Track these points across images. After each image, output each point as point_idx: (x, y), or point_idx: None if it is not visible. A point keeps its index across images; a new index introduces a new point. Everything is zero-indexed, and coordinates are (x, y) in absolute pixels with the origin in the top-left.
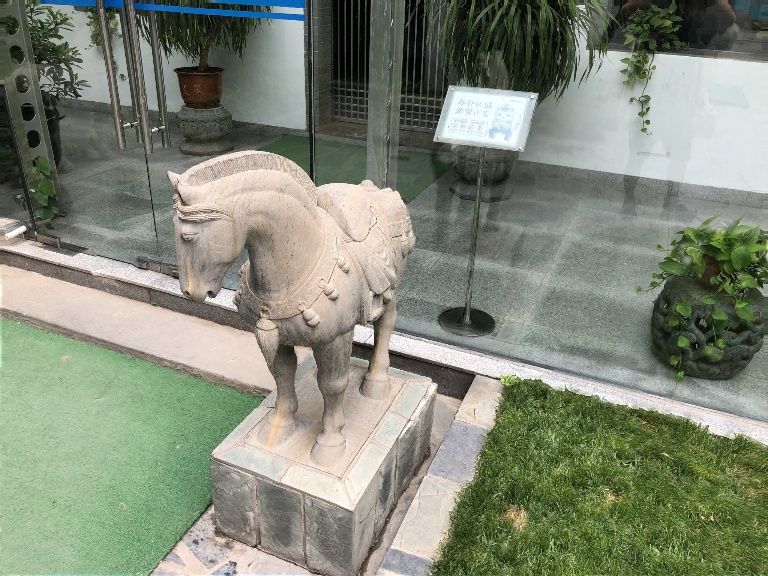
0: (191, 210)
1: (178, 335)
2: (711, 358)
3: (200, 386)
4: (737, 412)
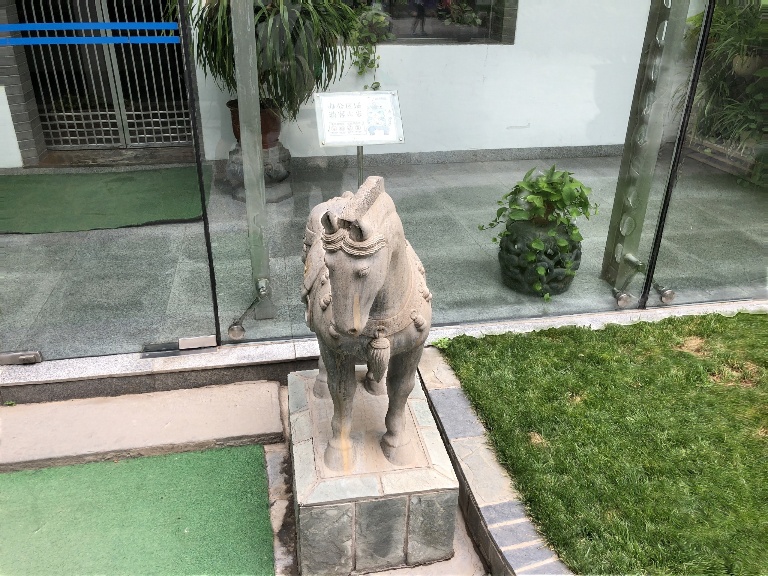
0: (369, 244)
1: (76, 425)
2: (560, 277)
3: (149, 465)
4: (591, 310)
